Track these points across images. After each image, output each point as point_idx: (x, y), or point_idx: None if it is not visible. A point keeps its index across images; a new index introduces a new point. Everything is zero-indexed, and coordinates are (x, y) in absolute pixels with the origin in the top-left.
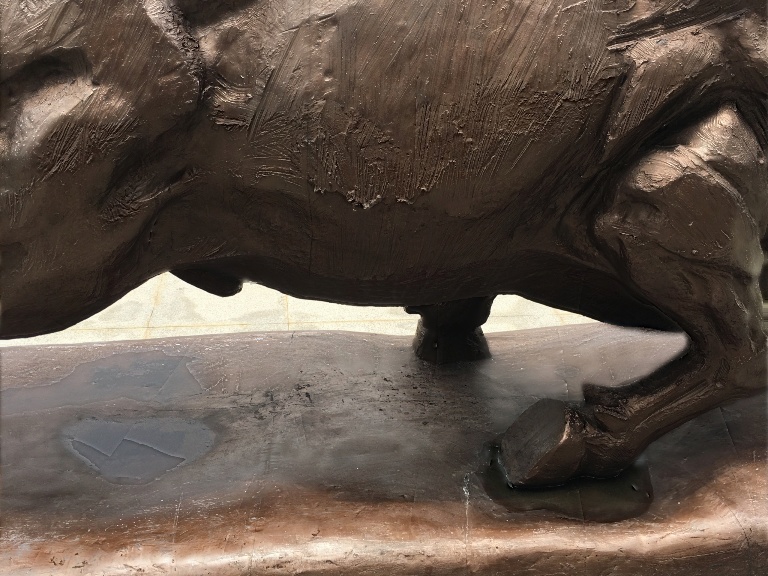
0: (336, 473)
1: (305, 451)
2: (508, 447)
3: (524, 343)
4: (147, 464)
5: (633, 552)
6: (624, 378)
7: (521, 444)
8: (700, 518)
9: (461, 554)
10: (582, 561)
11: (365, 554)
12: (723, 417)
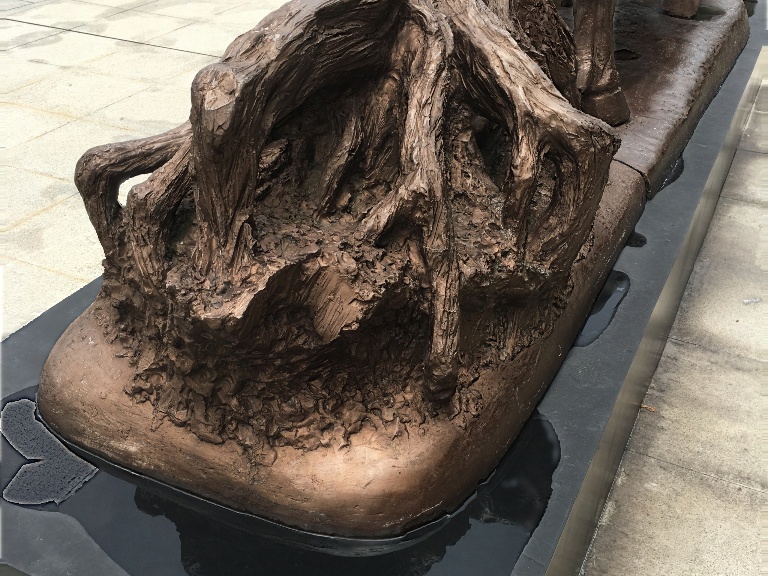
0: None
1: None
2: (672, 8)
3: None
4: None
5: (739, 18)
6: None
7: (679, 2)
8: (735, 3)
9: (727, 32)
10: (737, 25)
11: (719, 40)
12: None
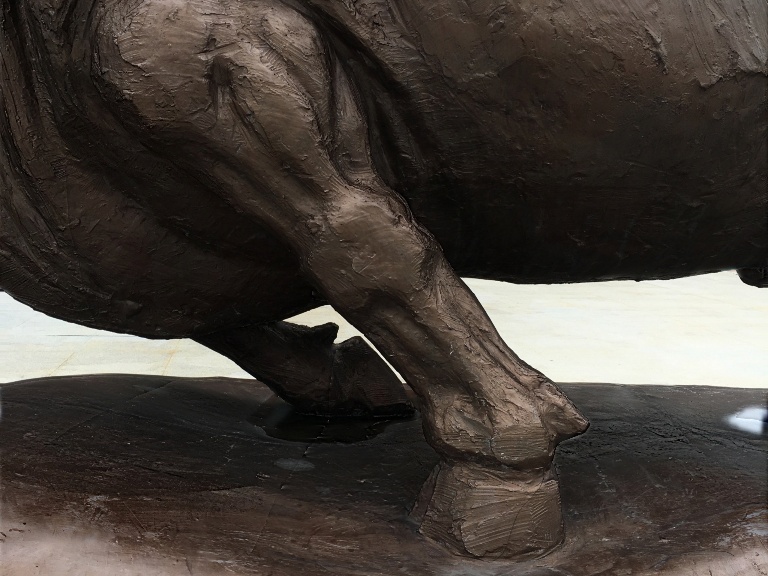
0: (573, 390)
1: (615, 401)
2: None
3: (335, 549)
4: (767, 415)
5: None
6: (220, 439)
7: None
8: None
9: None
10: None
11: None
12: (153, 390)
